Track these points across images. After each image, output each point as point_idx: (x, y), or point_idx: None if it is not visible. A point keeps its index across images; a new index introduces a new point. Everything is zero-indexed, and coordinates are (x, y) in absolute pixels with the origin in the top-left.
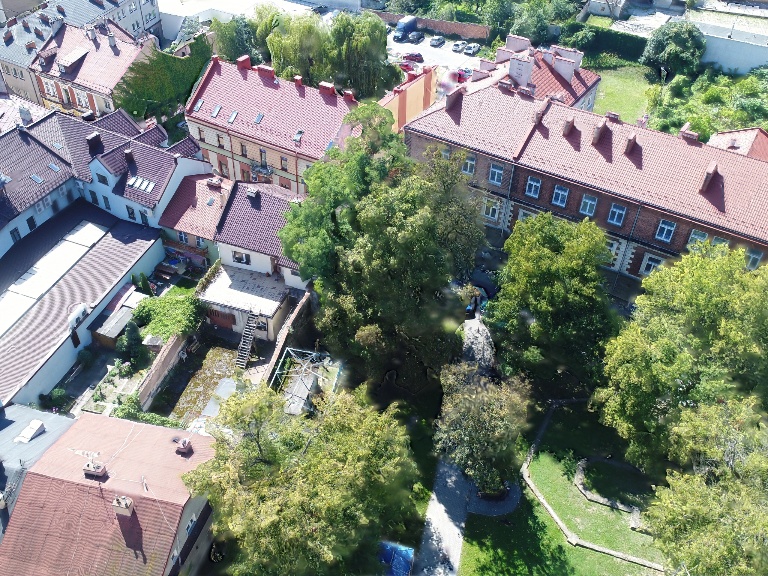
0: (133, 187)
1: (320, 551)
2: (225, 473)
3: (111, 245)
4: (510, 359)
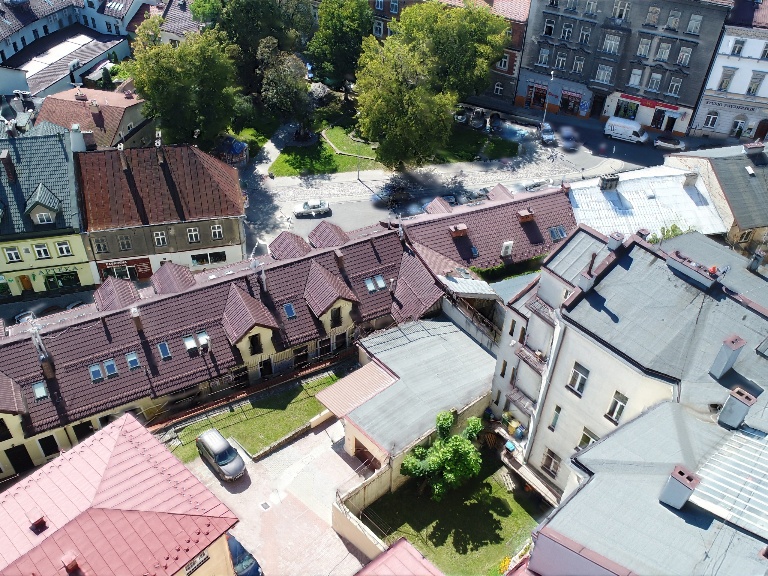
0: (110, 8)
1: (176, 68)
2: (136, 42)
3: (96, 44)
4: (318, 74)
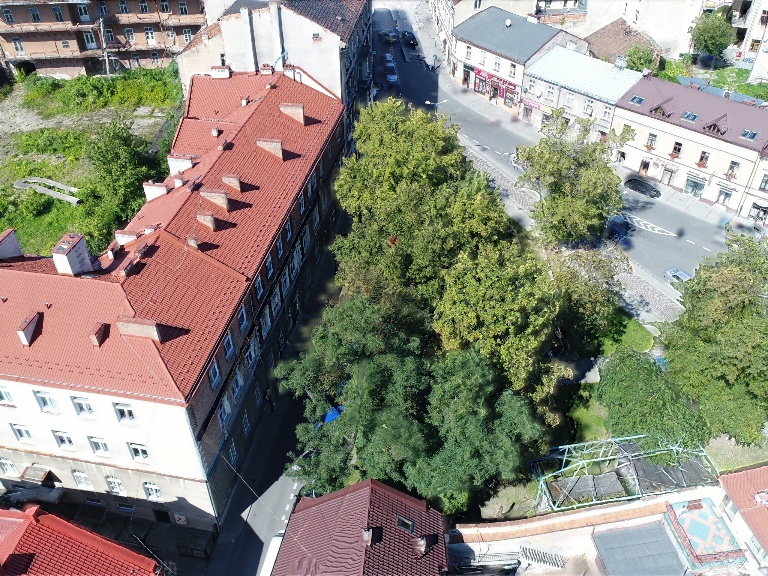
0: None
1: None
2: None
3: None
4: None
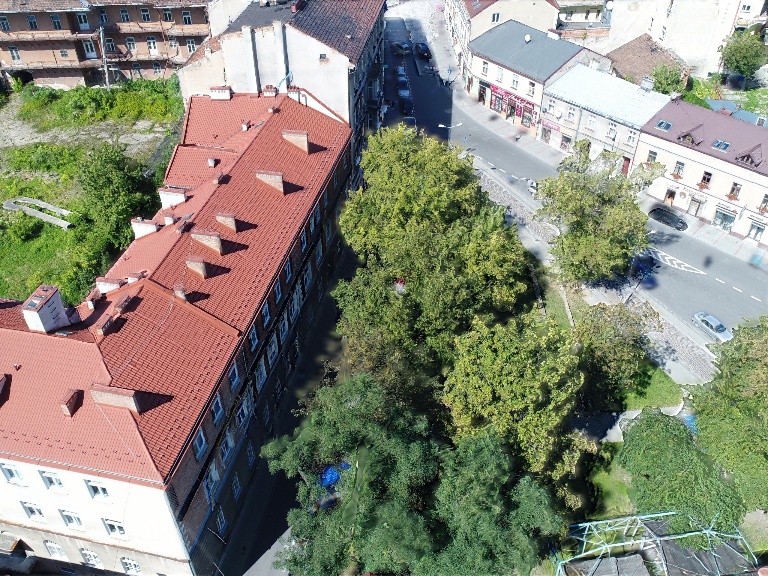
0: None
1: None
2: None
3: None
4: None
